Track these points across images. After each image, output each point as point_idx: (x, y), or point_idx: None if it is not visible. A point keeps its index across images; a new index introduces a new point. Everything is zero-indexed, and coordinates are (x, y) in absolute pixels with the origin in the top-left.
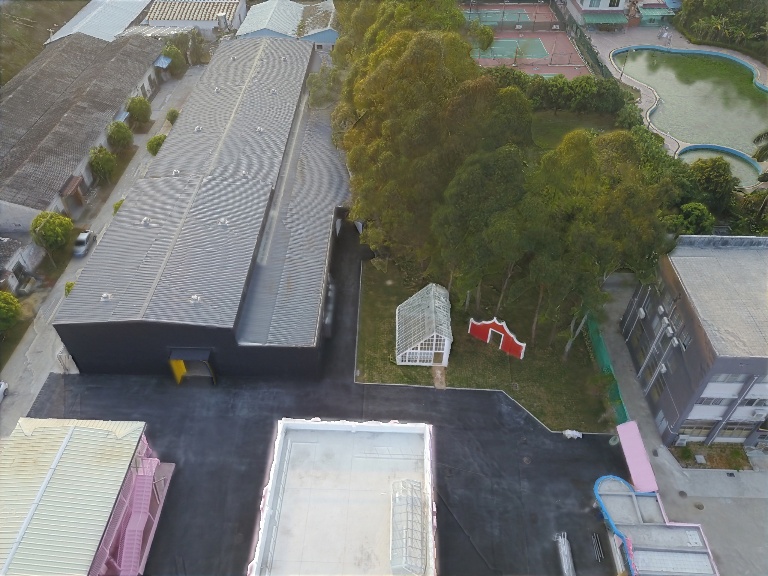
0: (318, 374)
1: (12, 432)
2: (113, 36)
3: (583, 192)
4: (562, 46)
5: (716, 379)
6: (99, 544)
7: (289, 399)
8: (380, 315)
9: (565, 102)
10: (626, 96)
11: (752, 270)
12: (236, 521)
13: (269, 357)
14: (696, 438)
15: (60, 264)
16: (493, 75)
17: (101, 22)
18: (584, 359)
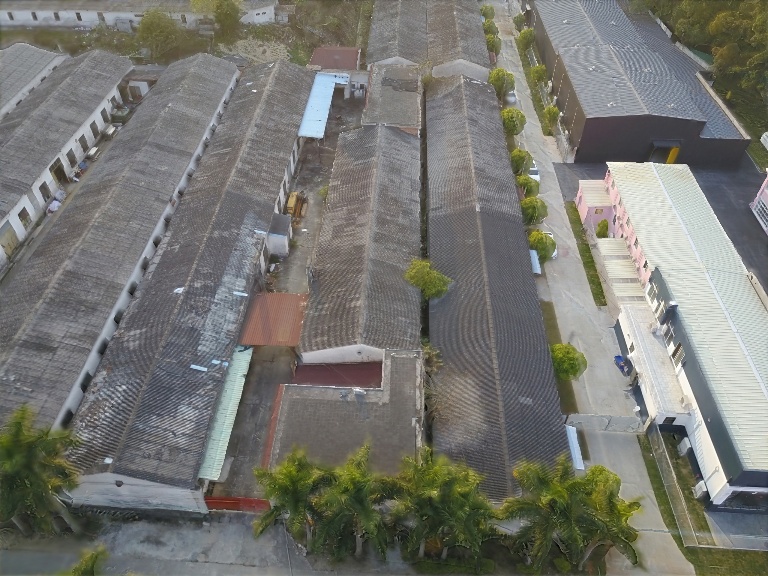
0: (737, 165)
1: (609, 167)
2: None
3: None
4: None
5: None
6: (713, 211)
7: (725, 178)
8: None
9: None
10: None
11: None
12: (738, 231)
13: (715, 148)
14: None
15: None
16: None
17: None
18: None
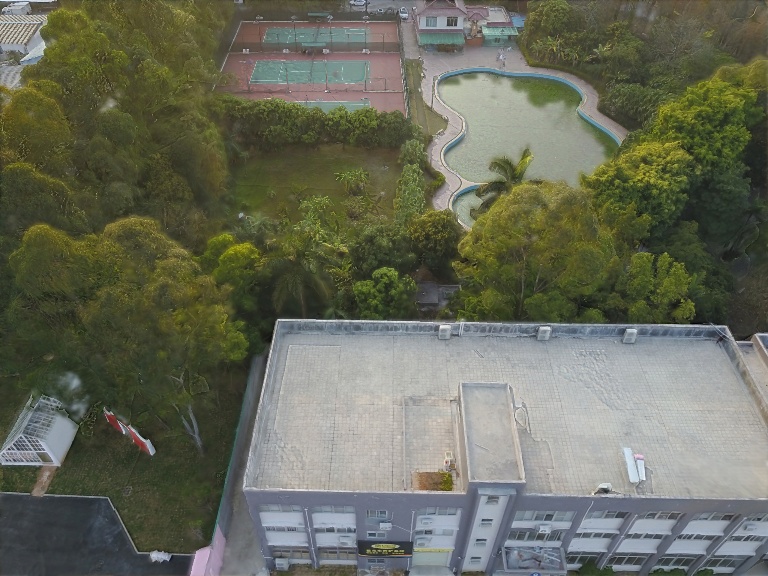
0: None
1: None
2: None
3: (63, 297)
4: (388, 69)
5: (268, 508)
6: None
7: None
8: (17, 399)
9: (344, 137)
10: (415, 130)
11: (372, 363)
12: None
13: None
14: (301, 560)
15: None
16: (260, 109)
17: None
18: (222, 455)
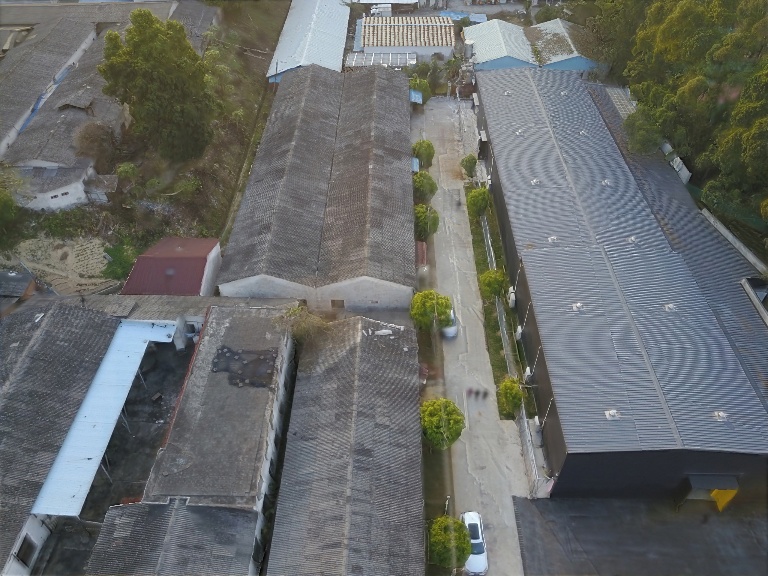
0: None
1: None
2: (337, 66)
3: None
4: None
5: None
6: None
7: None
8: None
9: None
10: None
11: None
12: None
13: None
14: None
15: (435, 349)
16: None
17: (319, 50)
18: None
